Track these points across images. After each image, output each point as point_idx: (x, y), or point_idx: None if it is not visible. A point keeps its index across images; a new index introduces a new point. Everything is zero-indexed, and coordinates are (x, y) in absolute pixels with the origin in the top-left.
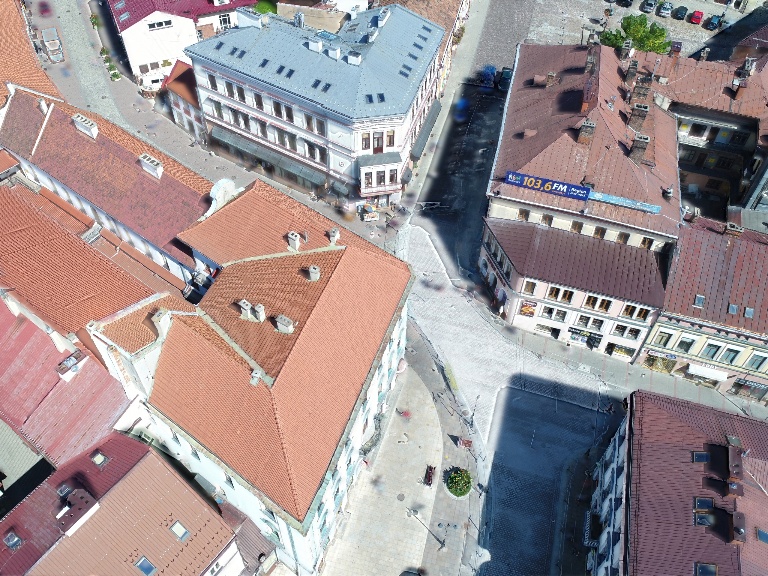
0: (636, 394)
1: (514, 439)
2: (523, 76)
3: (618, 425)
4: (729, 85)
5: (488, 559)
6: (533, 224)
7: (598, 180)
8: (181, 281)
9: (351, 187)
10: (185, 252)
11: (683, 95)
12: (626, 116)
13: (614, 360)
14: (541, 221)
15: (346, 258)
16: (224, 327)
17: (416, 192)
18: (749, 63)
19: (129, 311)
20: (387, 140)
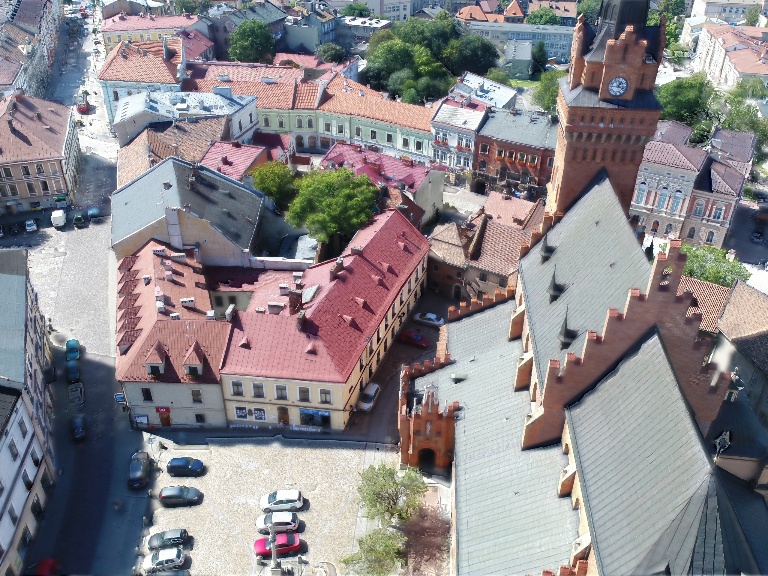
0: None
1: None
2: None
3: None
4: None
5: None
6: None
7: None
8: None
9: None
10: None
11: None
12: None
13: None
14: None
15: None
16: None
17: None
18: None
19: None
20: None
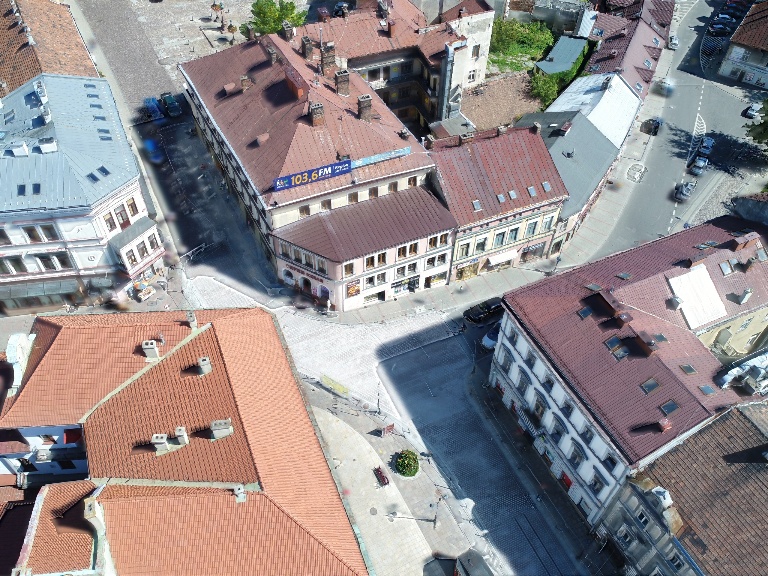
0: (506, 298)
1: (417, 400)
2: (209, 92)
3: (475, 336)
4: (379, 28)
5: (473, 504)
6: (316, 215)
7: (349, 150)
8: (6, 476)
9: (112, 276)
10: (4, 441)
11: (352, 51)
12: (330, 87)
13: (435, 290)
14: (321, 209)
15: (220, 333)
16: (147, 476)
17: (170, 247)
18: (383, 4)
19: (32, 533)
20: (129, 210)
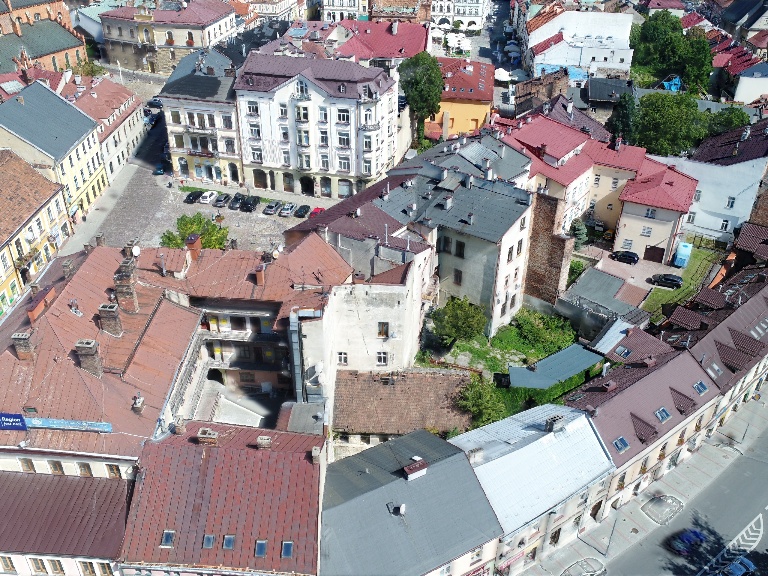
0: None
1: None
2: None
3: None
4: (254, 271)
5: None
6: None
7: (43, 402)
8: None
9: None
10: None
11: (202, 288)
12: None
13: None
14: None
15: None
16: None
17: None
18: (273, 246)
19: None
20: None
